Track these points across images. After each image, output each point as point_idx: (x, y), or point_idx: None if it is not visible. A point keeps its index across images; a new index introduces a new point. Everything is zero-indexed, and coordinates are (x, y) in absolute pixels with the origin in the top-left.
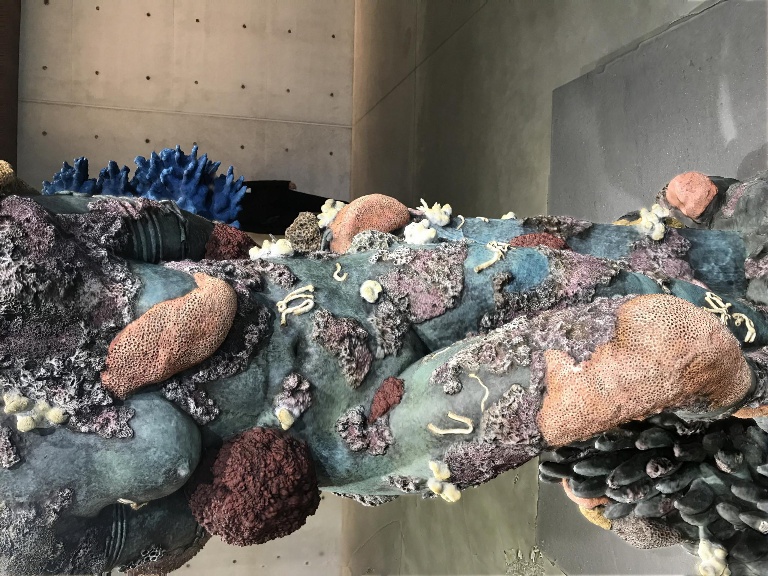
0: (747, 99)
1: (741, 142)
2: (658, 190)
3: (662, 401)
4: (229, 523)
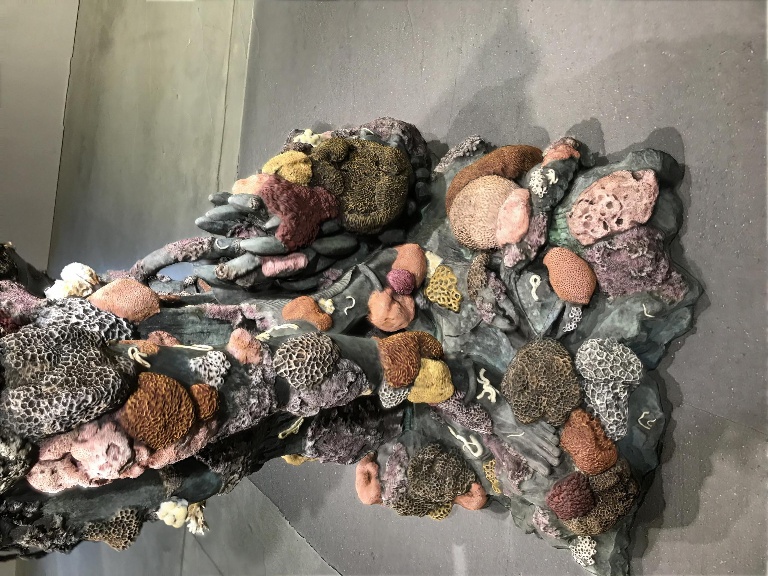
0: (439, 569)
1: (449, 535)
2: (556, 574)
3: None
4: None
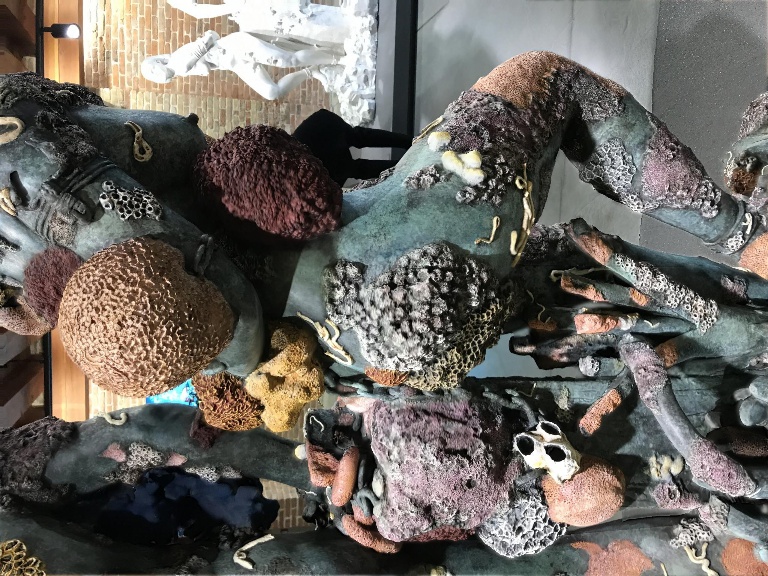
0: None
1: None
2: None
3: (543, 59)
4: (238, 131)
